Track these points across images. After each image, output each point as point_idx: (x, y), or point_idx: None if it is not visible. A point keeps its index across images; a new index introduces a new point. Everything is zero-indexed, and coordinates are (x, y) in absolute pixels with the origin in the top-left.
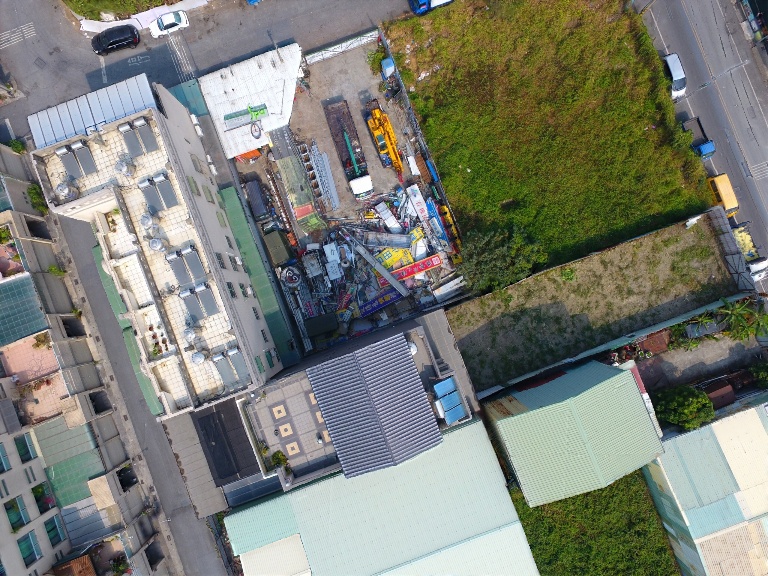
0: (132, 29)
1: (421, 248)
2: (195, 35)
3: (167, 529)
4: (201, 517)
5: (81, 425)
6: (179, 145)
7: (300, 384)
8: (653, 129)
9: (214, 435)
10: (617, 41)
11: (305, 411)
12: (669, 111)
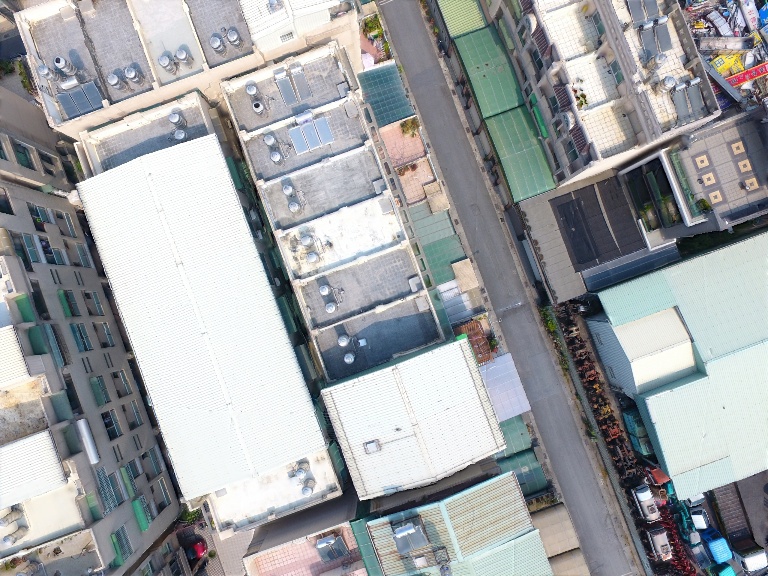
0: None
1: (749, 58)
2: None
3: (498, 329)
4: (560, 301)
5: (444, 210)
6: None
7: (722, 135)
8: None
9: (574, 221)
10: None
11: (727, 161)
12: None
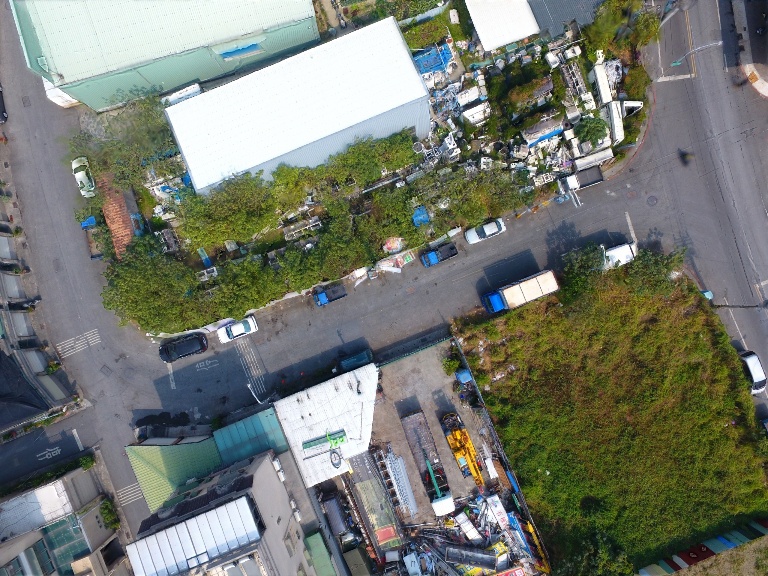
0: (201, 338)
1: (502, 555)
2: (264, 337)
3: None
4: None
5: None
6: (277, 551)
7: None
8: (733, 426)
9: None
10: (694, 336)
11: None
12: (750, 414)
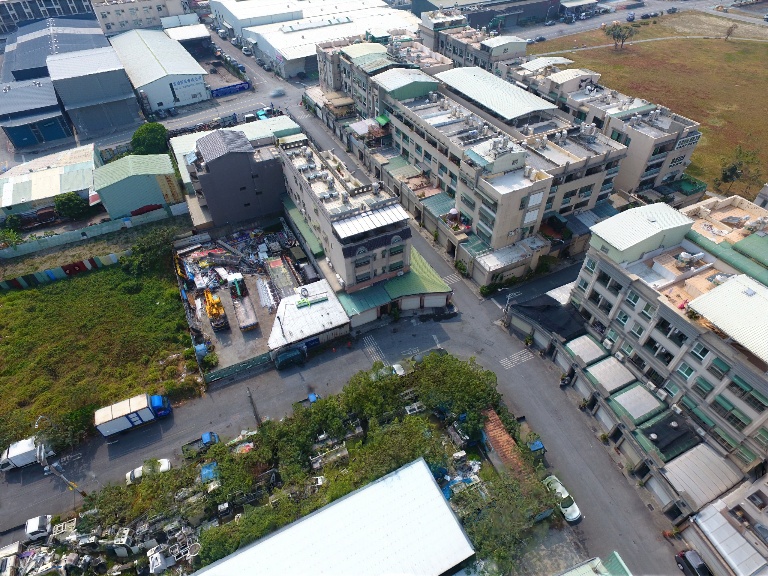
0: (416, 365)
1: None
2: None
3: (359, 166)
4: None
5: None
6: None
7: None
8: (2, 336)
9: None
10: None
11: None
12: None
